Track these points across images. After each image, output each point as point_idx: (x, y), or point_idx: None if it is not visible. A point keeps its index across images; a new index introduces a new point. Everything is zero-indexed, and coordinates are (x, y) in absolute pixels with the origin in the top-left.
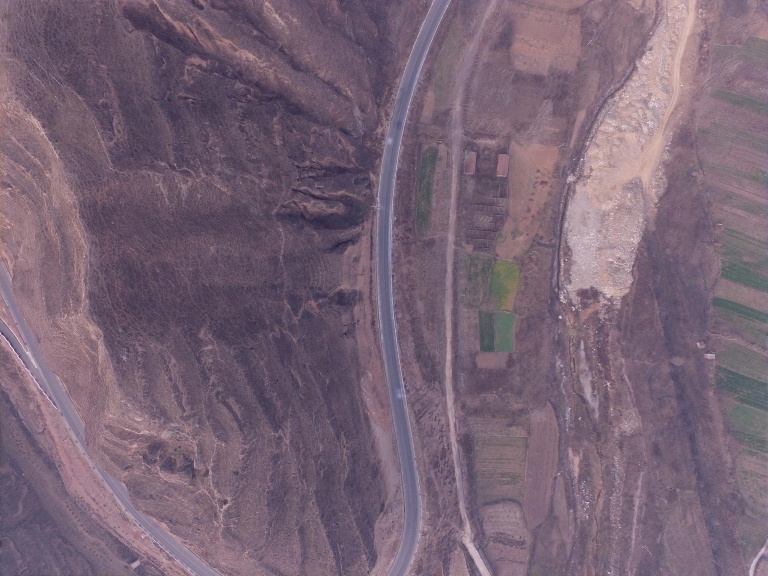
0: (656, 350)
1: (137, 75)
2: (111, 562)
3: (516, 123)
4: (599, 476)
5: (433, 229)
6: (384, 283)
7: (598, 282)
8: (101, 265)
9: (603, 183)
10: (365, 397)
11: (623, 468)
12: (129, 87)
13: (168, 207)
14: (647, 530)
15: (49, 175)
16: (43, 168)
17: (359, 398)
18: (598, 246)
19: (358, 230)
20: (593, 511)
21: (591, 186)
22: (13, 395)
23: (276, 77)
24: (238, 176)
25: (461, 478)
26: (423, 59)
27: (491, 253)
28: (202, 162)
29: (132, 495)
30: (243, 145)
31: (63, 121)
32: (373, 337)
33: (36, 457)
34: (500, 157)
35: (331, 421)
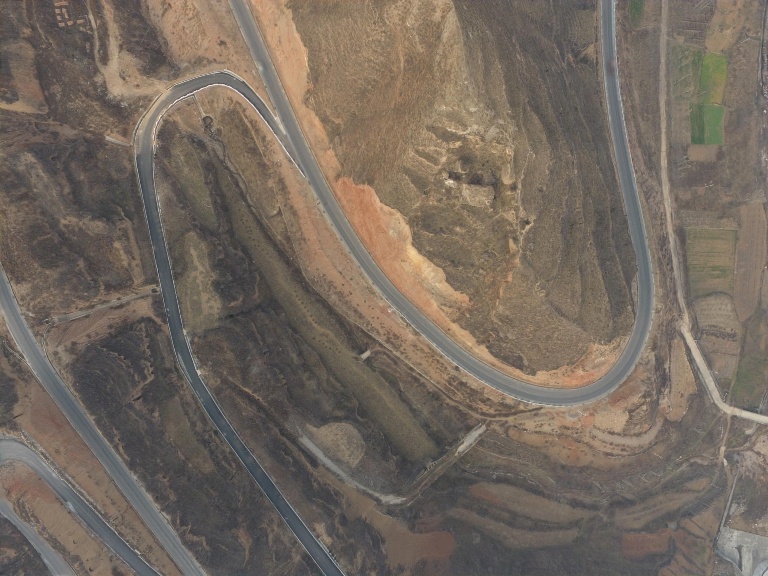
0: None
1: None
2: (340, 354)
3: None
4: None
5: (646, 20)
6: (609, 65)
7: None
8: None
9: None
10: None
11: None
12: None
13: None
14: None
15: None
16: None
17: (611, 158)
18: None
19: (595, 0)
20: None
21: None
22: (245, 177)
23: None
24: None
25: (678, 267)
26: None
27: (701, 45)
28: None
29: (417, 233)
30: None
31: None
32: None
33: (266, 244)
34: None
35: (600, 168)
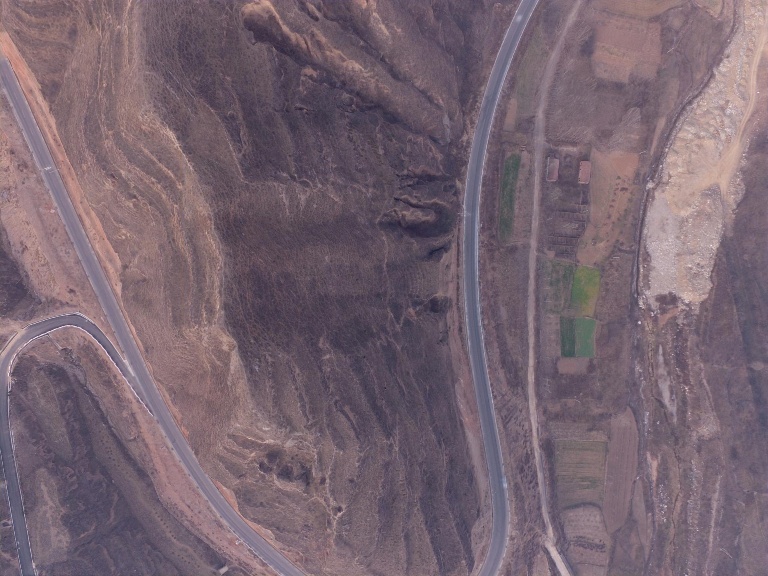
0: (735, 355)
1: (259, 87)
2: (199, 568)
3: (597, 130)
4: (677, 480)
5: (515, 236)
6: (471, 290)
7: (676, 288)
8: (234, 276)
9: (682, 189)
10: (459, 403)
11: (701, 472)
12: (252, 99)
13: (288, 217)
14: (725, 533)
15: (181, 187)
16: (175, 180)
17: (455, 405)
18: (677, 252)
19: (450, 237)
20: (671, 514)
21: (670, 192)
22: (104, 403)
23: (377, 86)
24: (348, 186)
25: (543, 482)
26: (507, 67)
27: (572, 259)
28: (318, 172)
29: (241, 503)
30: (352, 155)
31: (196, 133)
32: (460, 343)
33: (126, 464)
34: (582, 164)
35: (433, 428)
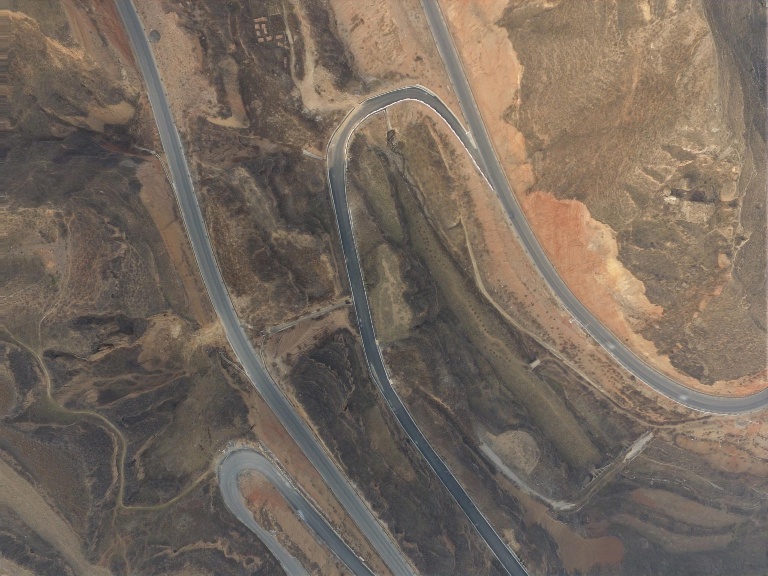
0: None
1: None
2: (510, 363)
3: None
4: None
5: None
6: None
7: None
8: None
9: None
10: None
11: None
12: None
13: None
14: None
15: None
16: None
17: None
18: None
19: None
20: None
21: None
22: (426, 189)
23: None
24: None
25: None
26: None
27: None
28: None
29: (626, 247)
30: None
31: None
32: None
33: (442, 255)
34: None
35: None
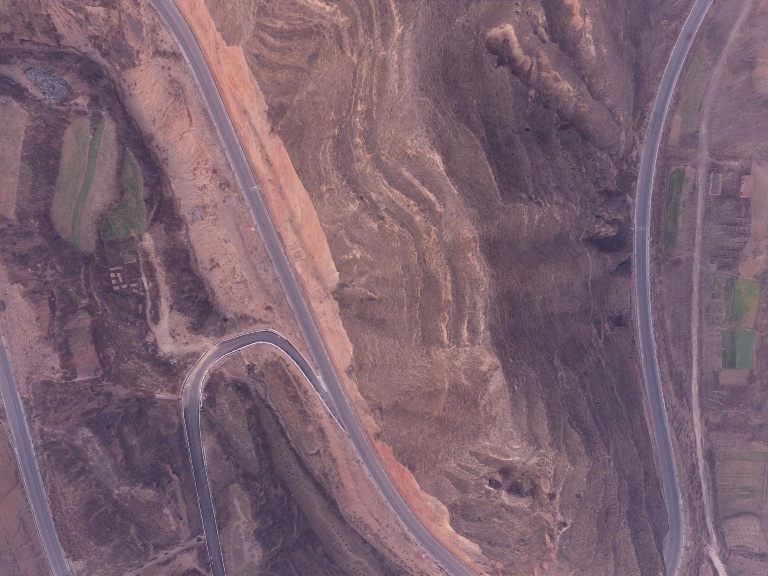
0: None
1: (500, 109)
2: None
3: None
4: None
5: (679, 249)
6: (643, 303)
7: None
8: (497, 297)
9: None
10: (645, 416)
11: None
12: (493, 121)
13: (524, 237)
14: None
15: (442, 210)
16: (435, 203)
17: None
18: None
19: None
20: None
21: None
22: (286, 417)
23: (575, 105)
24: (565, 204)
25: (707, 493)
26: (674, 83)
27: (734, 272)
28: (546, 192)
29: (456, 518)
30: (567, 174)
31: (457, 157)
32: (634, 356)
33: (304, 478)
34: (746, 178)
35: (634, 442)
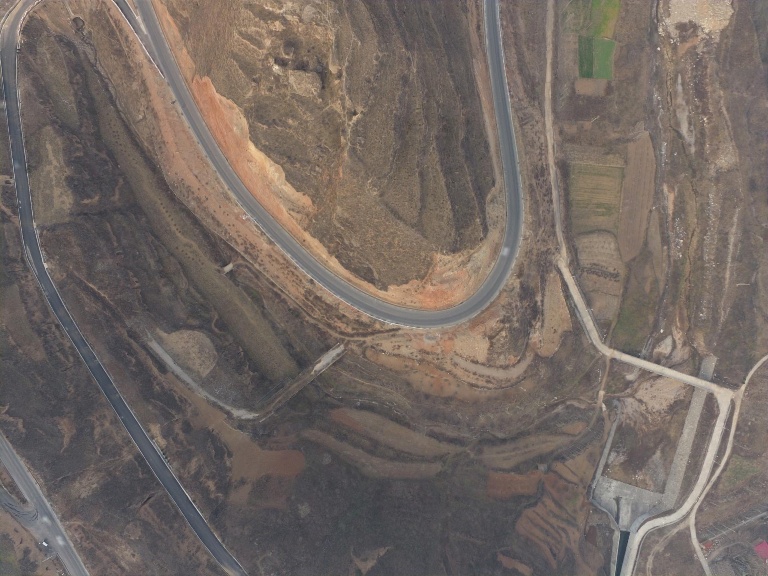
0: (755, 83)
1: None
2: (203, 266)
3: None
4: (693, 214)
5: None
6: None
7: (697, 16)
8: None
9: None
10: (477, 78)
11: (719, 204)
12: None
13: None
14: (742, 268)
15: None
16: None
17: (473, 73)
18: None
19: None
20: (687, 250)
21: None
22: (114, 80)
23: None
24: None
25: (558, 200)
26: None
27: None
28: None
29: (252, 125)
30: None
31: None
32: (478, 41)
33: (132, 150)
34: None
35: (451, 75)
